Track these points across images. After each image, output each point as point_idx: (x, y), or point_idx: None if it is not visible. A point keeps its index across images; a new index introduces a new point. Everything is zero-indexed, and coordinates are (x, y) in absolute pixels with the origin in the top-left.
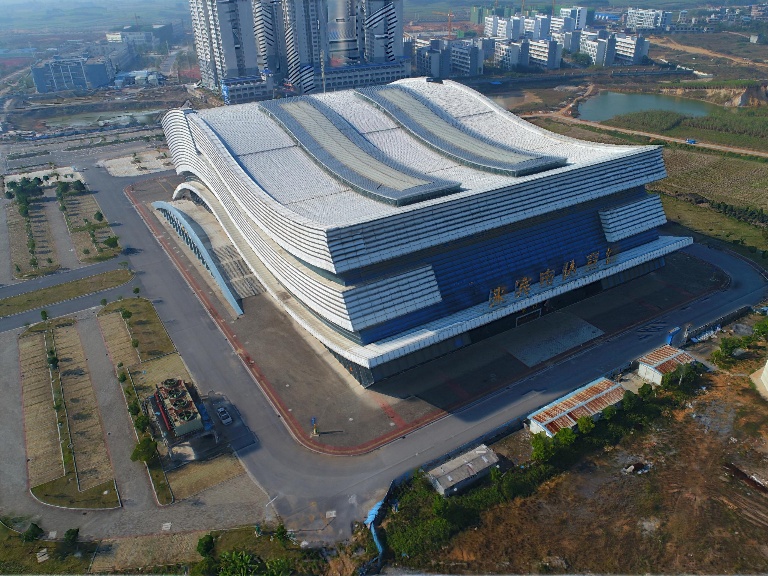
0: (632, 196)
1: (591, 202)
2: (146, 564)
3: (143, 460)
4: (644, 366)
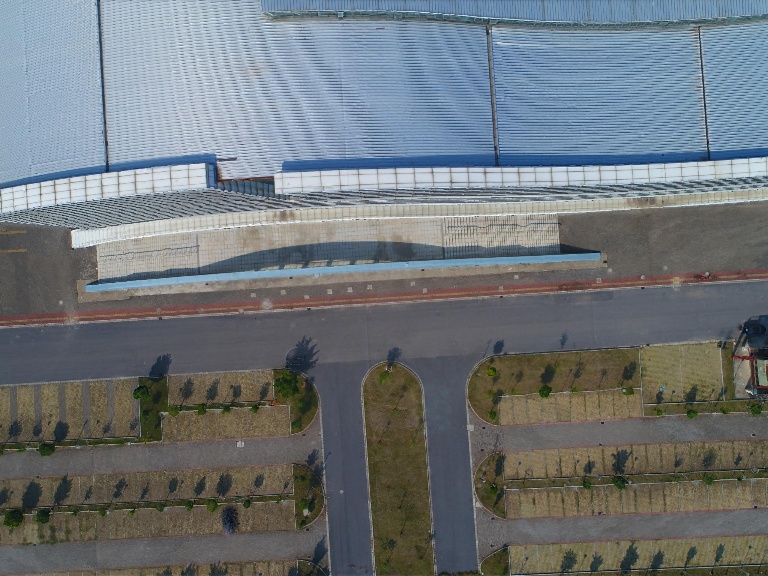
0: None
1: None
2: None
3: None
4: None
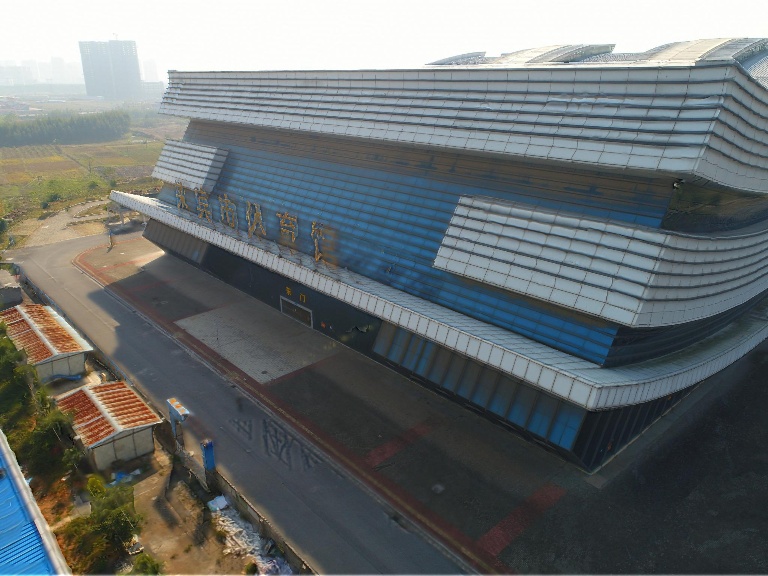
0: (600, 209)
1: (472, 172)
2: None
3: None
4: None
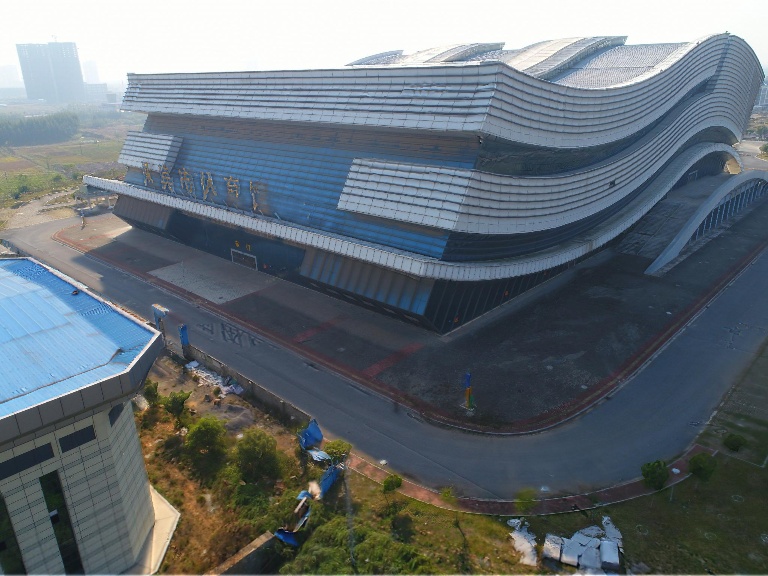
0: (440, 160)
1: (363, 142)
2: None
3: (70, 195)
4: None
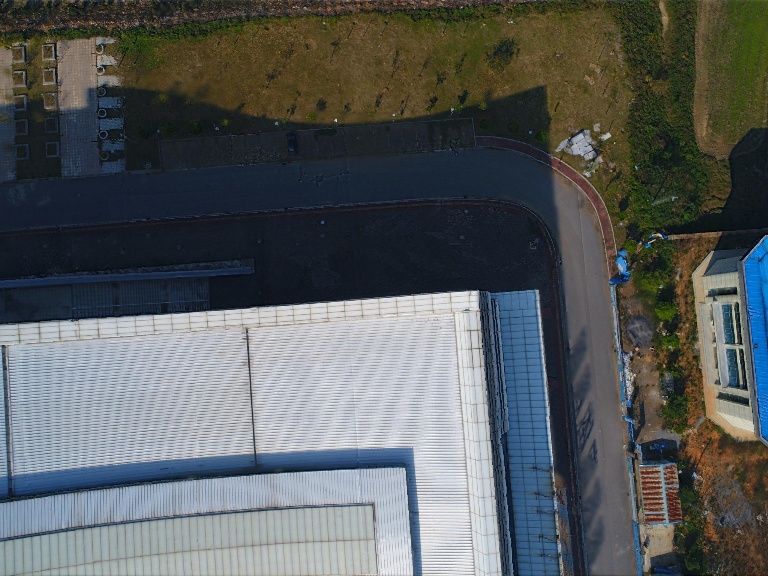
0: None
1: None
2: None
3: None
4: (657, 524)
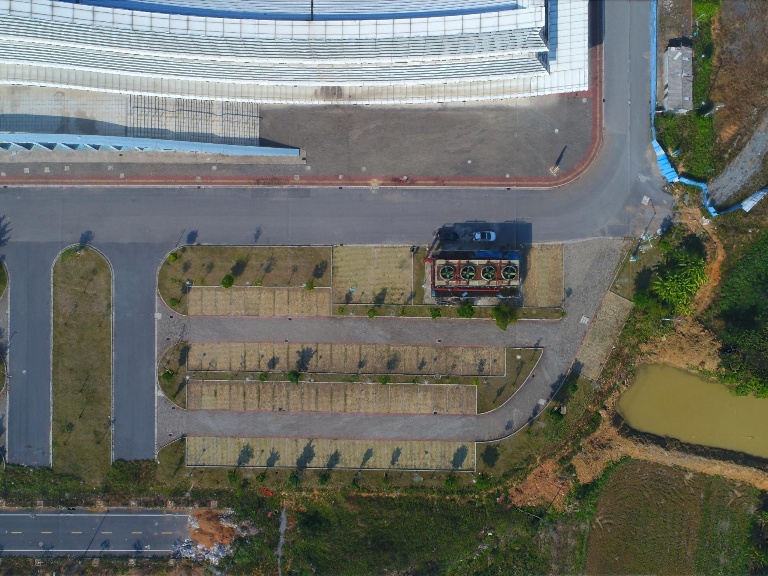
0: None
1: None
2: (613, 342)
3: None
4: None
